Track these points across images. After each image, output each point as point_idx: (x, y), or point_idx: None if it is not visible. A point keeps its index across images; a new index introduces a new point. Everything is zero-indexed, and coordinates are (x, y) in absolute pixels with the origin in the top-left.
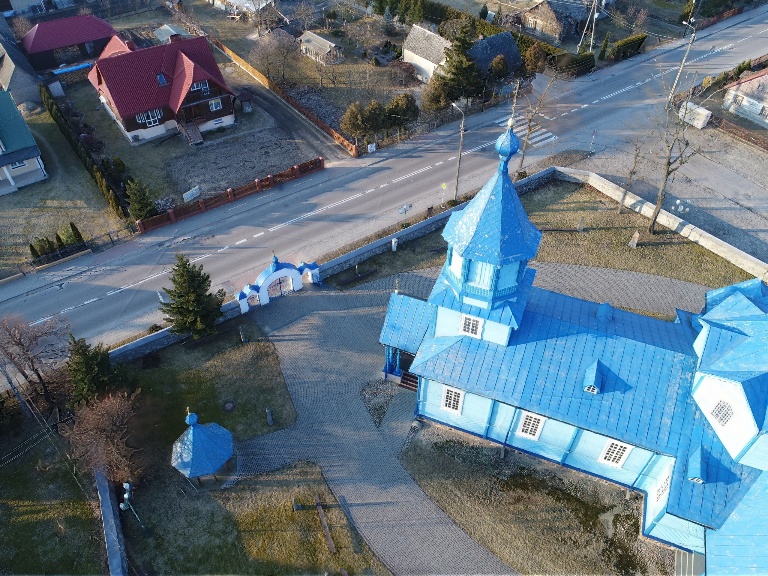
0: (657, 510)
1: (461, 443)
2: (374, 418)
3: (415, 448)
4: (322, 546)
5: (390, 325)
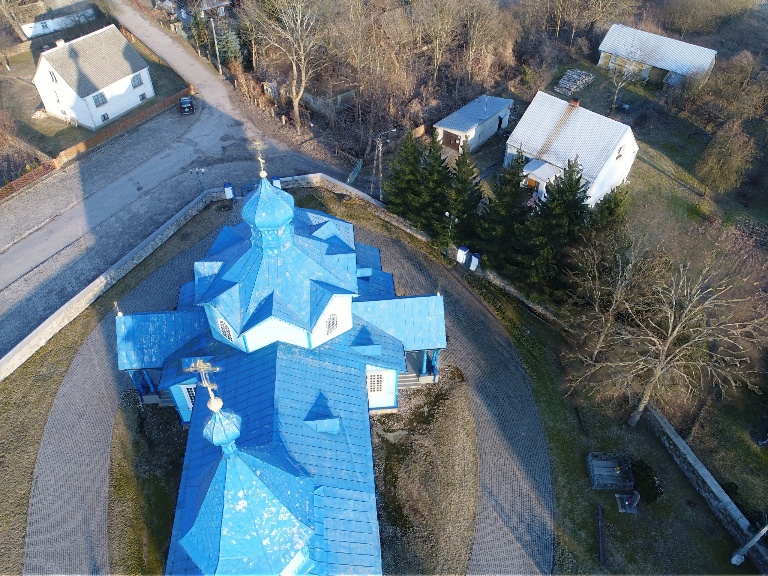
0: (390, 389)
1: None
2: None
3: None
4: None
5: None
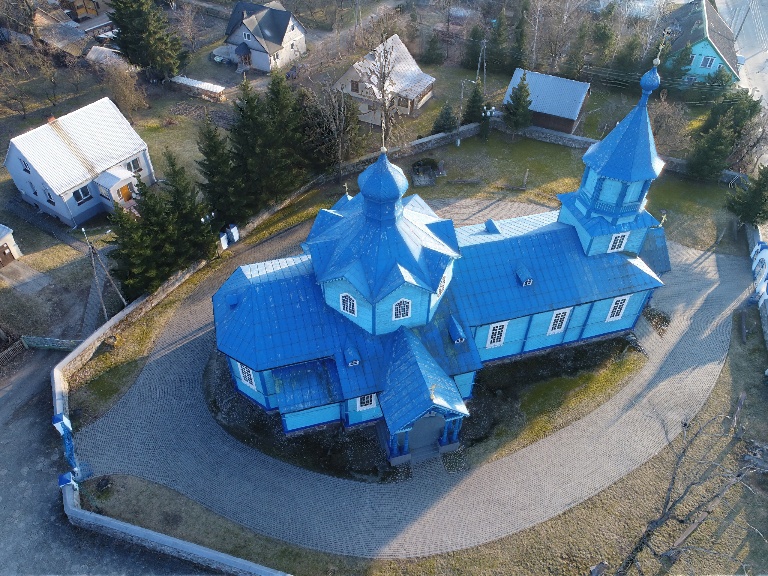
0: None
1: None
2: None
3: None
4: None
5: None
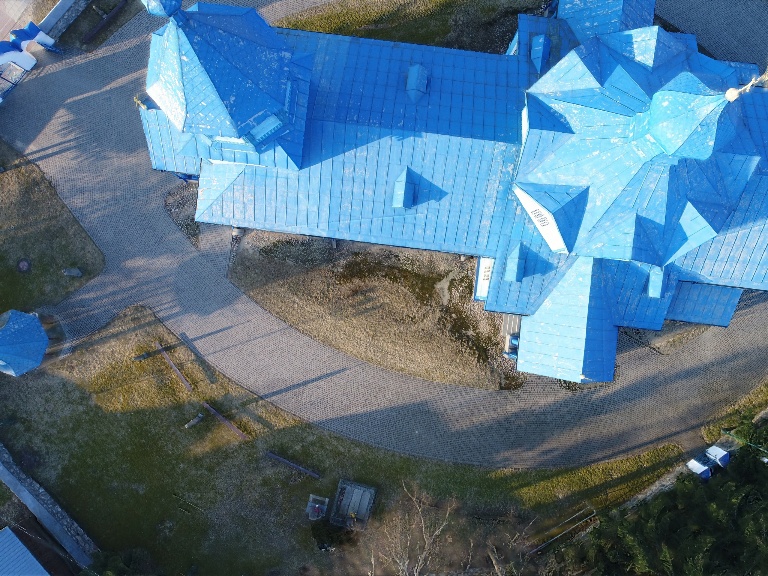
0: (483, 291)
1: (289, 242)
2: (189, 237)
3: (242, 261)
4: (179, 386)
5: (156, 148)
